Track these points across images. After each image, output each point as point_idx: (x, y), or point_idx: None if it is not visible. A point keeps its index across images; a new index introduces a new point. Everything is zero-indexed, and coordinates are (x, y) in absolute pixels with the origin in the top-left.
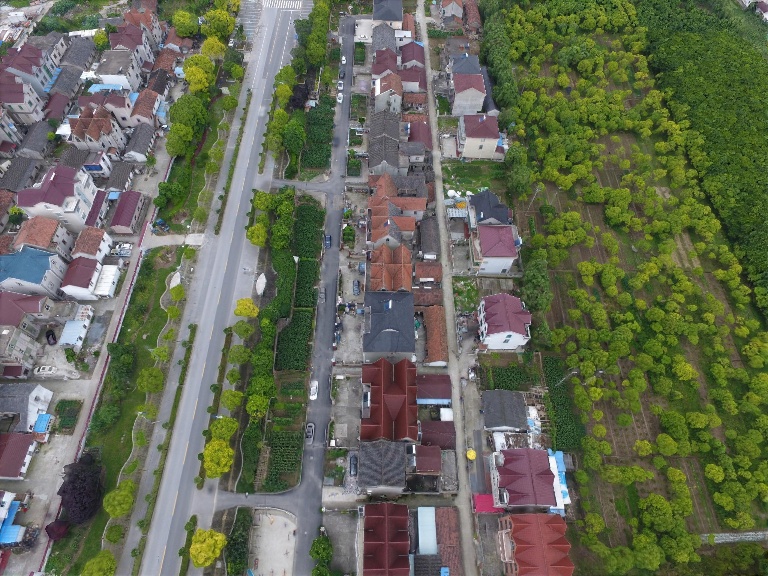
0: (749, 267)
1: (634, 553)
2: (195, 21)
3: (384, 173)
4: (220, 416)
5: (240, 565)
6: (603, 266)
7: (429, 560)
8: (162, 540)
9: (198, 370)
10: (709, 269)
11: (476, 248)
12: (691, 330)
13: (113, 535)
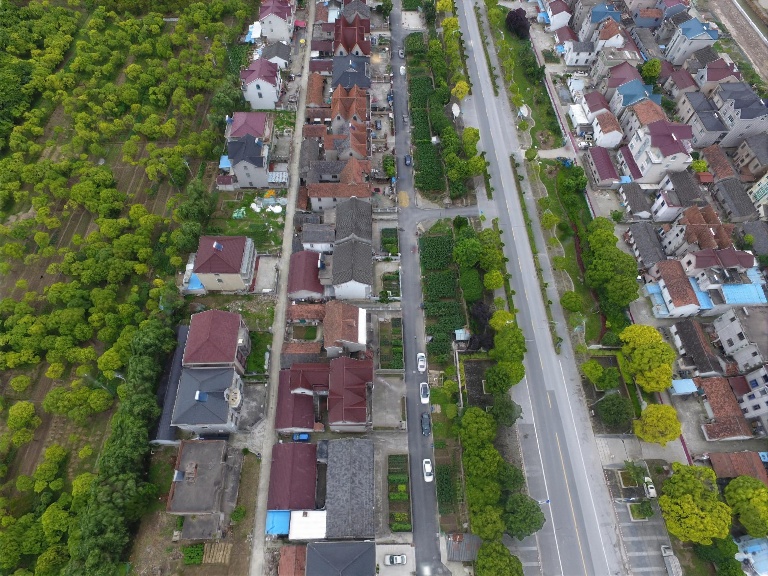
0: (6, 129)
1: (225, 5)
2: (742, 507)
3: (354, 181)
4: (455, 31)
5: (426, 1)
6: (151, 129)
7: (333, 3)
8: (469, 18)
9: (482, 74)
10: (40, 144)
11: (269, 129)
12: (108, 88)
13: (491, 6)
